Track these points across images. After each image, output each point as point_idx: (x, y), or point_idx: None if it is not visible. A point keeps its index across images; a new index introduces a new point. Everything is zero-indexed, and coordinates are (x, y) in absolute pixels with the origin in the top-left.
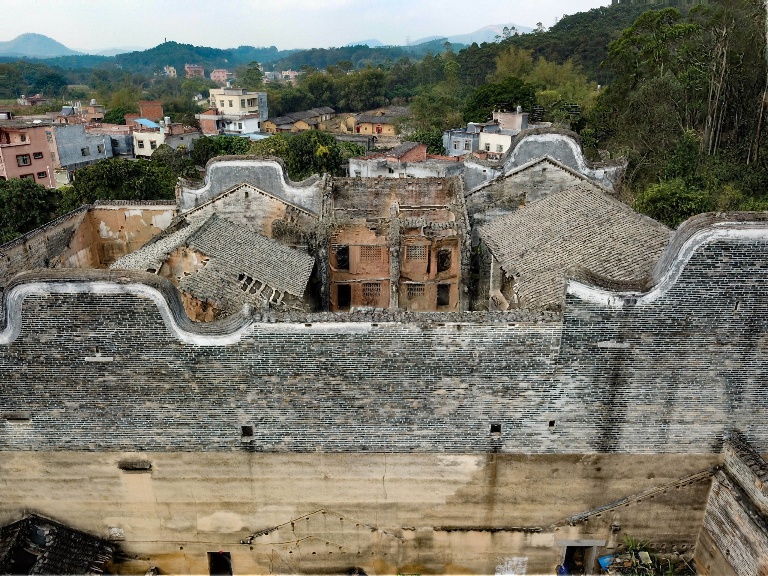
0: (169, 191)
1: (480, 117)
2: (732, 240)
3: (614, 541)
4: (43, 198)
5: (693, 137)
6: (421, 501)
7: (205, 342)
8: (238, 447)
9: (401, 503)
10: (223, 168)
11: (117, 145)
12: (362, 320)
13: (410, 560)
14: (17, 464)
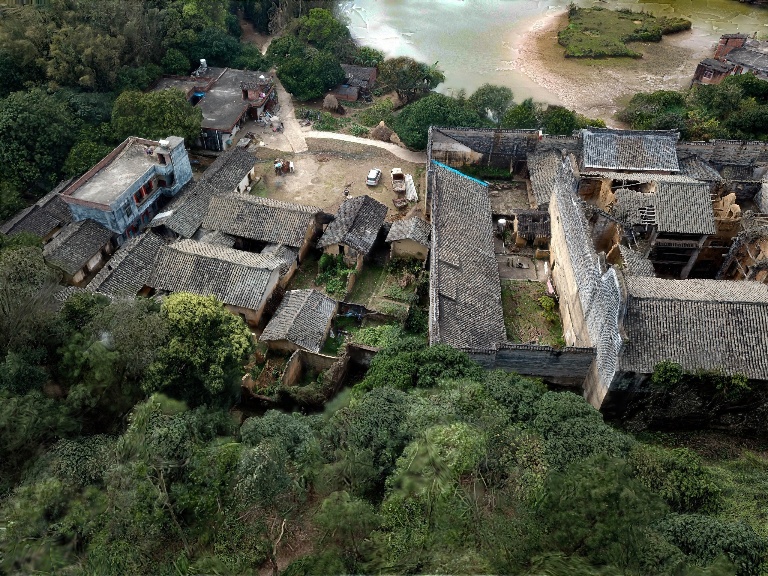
0: None
1: None
2: None
3: None
4: None
5: None
6: (569, 289)
7: None
8: None
9: None
10: None
11: None
12: (582, 222)
13: None
14: None
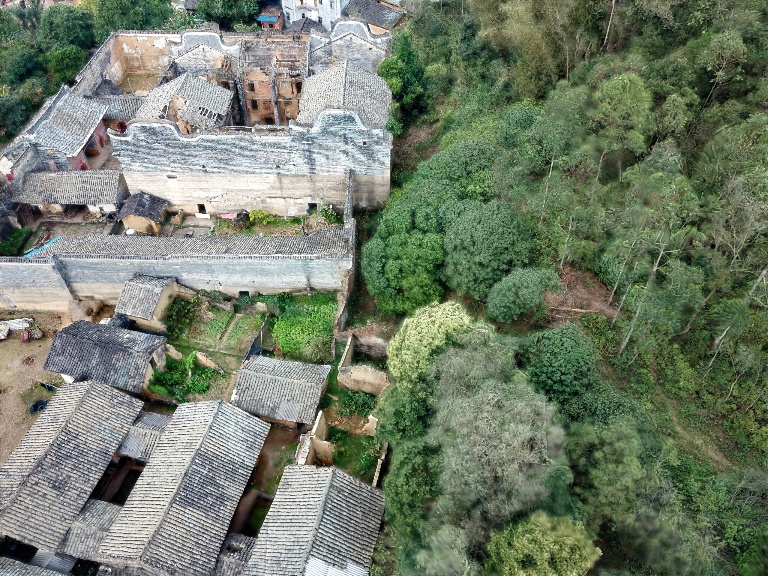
0: (159, 10)
1: None
2: (332, 114)
3: (322, 202)
4: (80, 19)
5: (405, 33)
6: (260, 188)
7: (187, 140)
8: (202, 171)
9: (254, 189)
10: (190, 36)
11: None
12: (232, 135)
13: (261, 207)
14: (136, 176)
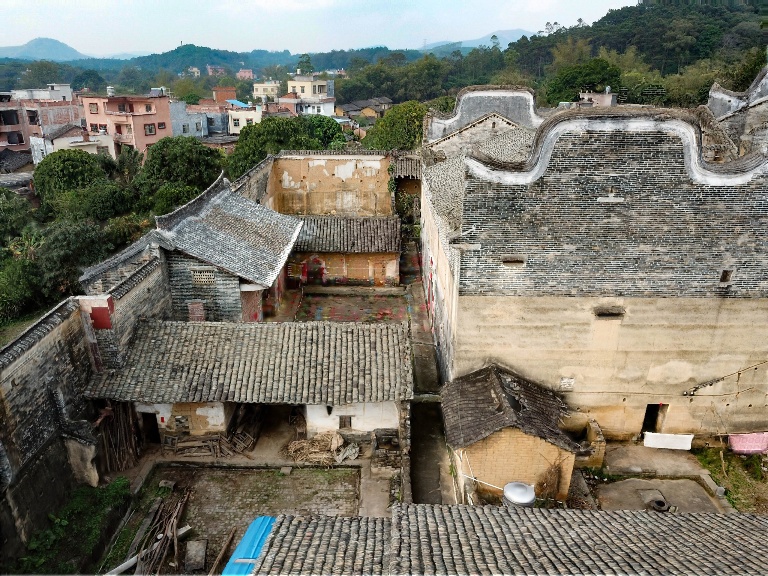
0: None
1: (567, 98)
2: None
3: None
4: (207, 155)
5: None
6: None
7: (716, 182)
8: (713, 292)
9: None
10: (475, 98)
11: (212, 123)
12: None
13: None
14: (496, 310)
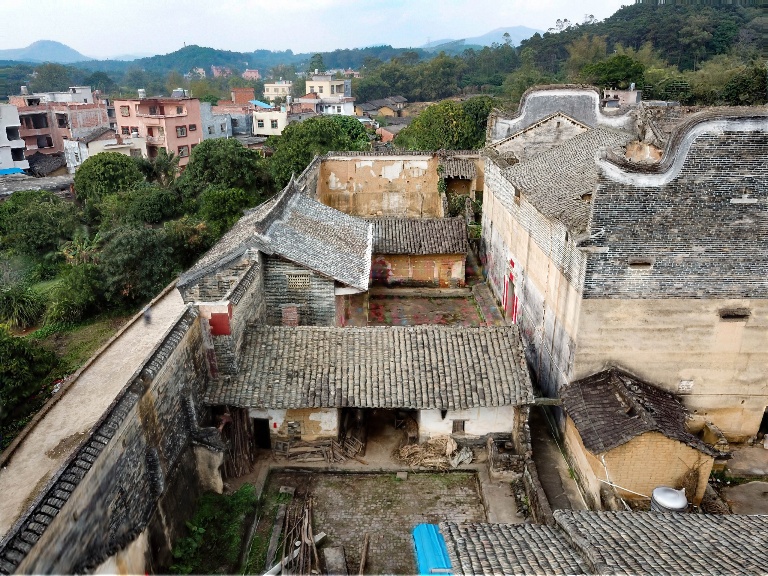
0: None
1: None
2: None
3: None
4: (248, 157)
5: None
6: None
7: None
8: None
9: None
10: (540, 98)
11: (236, 125)
12: None
13: None
14: (620, 312)
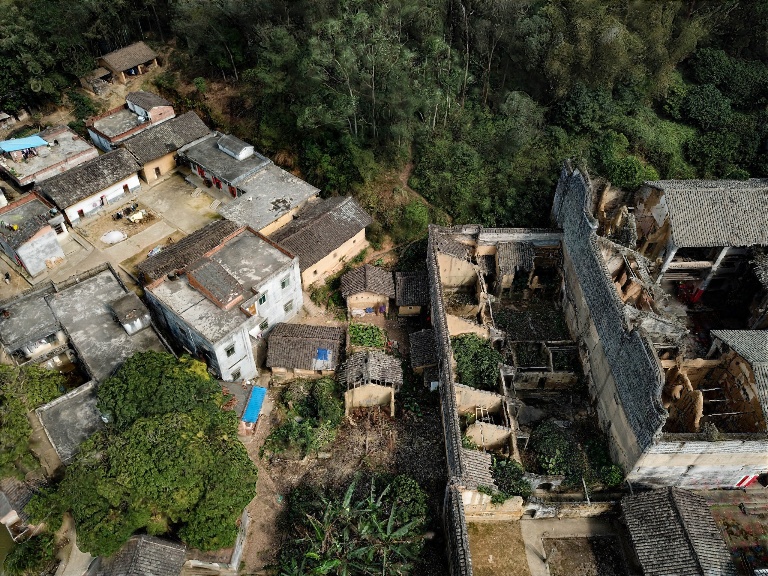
0: None
1: None
2: None
3: None
4: None
5: None
6: None
7: None
8: None
9: None
10: None
11: None
12: None
13: None
14: None
